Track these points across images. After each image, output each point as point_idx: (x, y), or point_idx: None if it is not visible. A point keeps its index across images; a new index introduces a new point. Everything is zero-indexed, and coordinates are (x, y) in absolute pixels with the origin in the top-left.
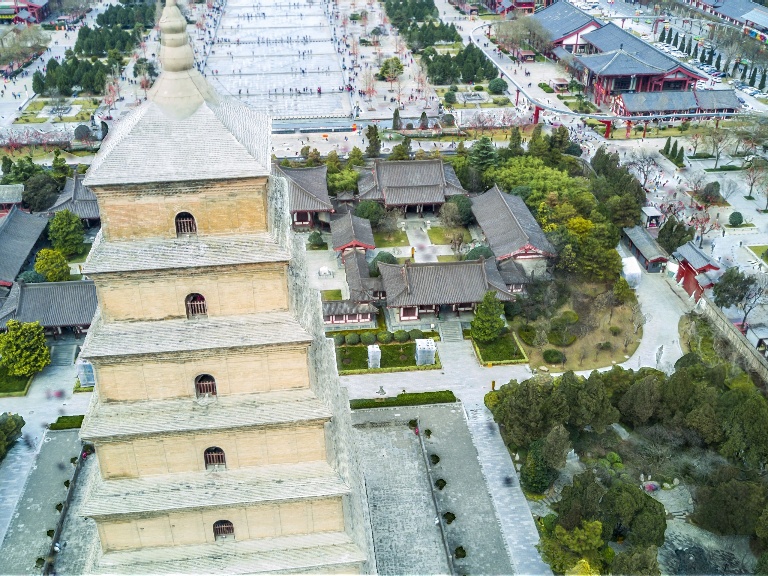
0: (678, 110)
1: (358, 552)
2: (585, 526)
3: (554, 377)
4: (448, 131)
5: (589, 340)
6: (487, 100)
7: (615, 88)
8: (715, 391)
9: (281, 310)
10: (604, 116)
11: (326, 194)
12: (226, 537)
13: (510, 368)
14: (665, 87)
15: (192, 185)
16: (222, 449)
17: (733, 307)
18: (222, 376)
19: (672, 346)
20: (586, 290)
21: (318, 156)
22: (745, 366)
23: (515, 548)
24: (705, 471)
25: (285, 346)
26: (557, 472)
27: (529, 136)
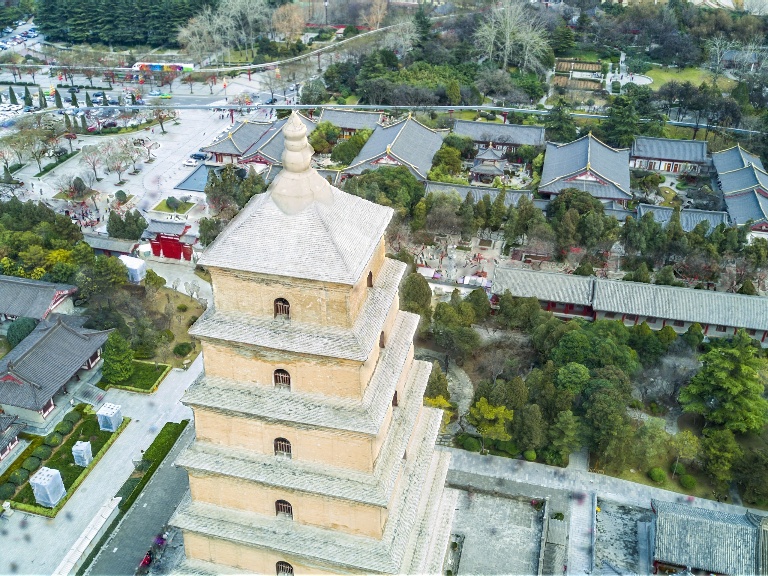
0: None
1: (447, 454)
2: None
3: None
4: None
5: (177, 326)
6: None
7: None
8: None
9: None
10: None
11: None
12: None
13: (169, 380)
14: None
15: None
16: None
17: None
18: None
19: None
20: (128, 297)
21: None
22: None
23: None
24: None
25: None
26: None
27: None
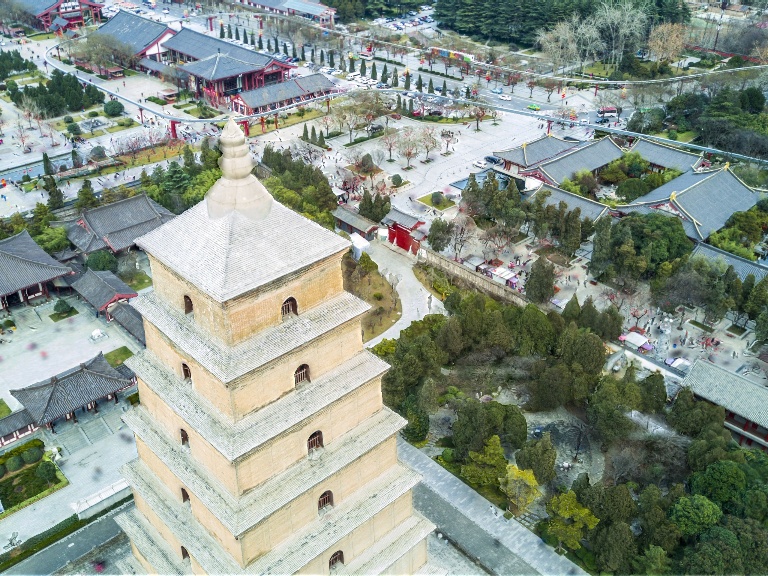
0: (290, 99)
1: (429, 525)
2: (488, 443)
3: (375, 348)
4: (103, 164)
5: None
6: (112, 124)
7: (225, 89)
8: (500, 313)
9: (359, 353)
10: (241, 117)
11: (51, 259)
12: (336, 567)
13: None
14: (265, 80)
15: (298, 272)
16: (331, 491)
17: (446, 249)
18: (327, 427)
19: (423, 293)
20: None
21: (2, 223)
22: (481, 290)
23: (438, 487)
24: (523, 371)
25: (371, 381)
26: (428, 418)
27: (199, 151)
